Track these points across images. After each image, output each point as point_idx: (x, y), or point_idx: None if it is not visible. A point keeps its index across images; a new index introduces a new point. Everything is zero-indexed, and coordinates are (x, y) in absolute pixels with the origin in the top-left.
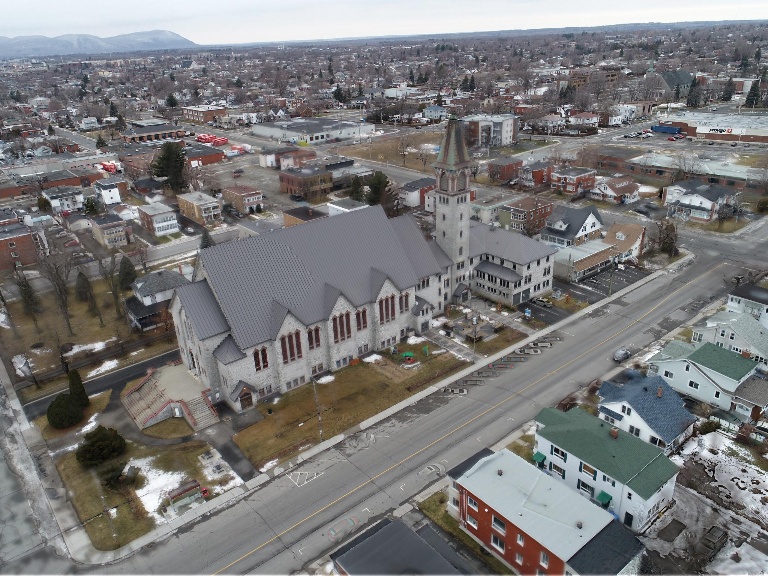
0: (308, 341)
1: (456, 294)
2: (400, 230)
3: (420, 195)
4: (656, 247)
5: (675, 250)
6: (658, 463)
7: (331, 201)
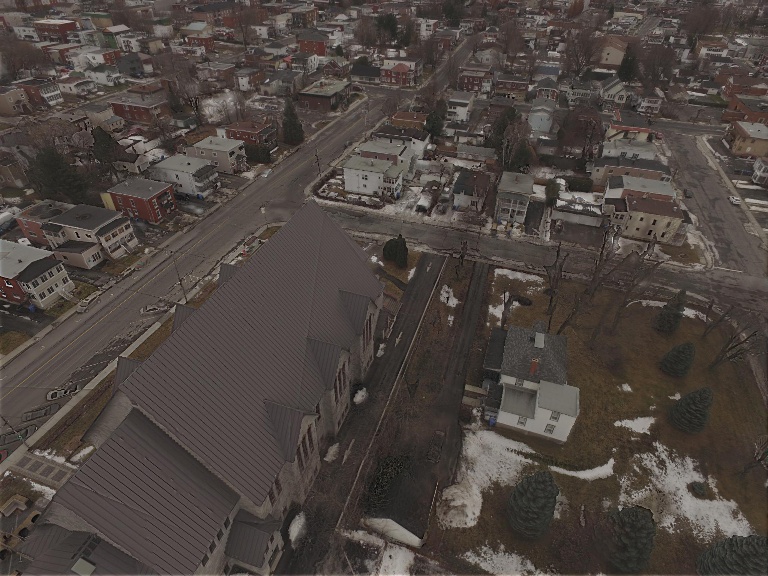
0: None
1: None
2: None
3: None
4: None
5: None
6: None
7: None
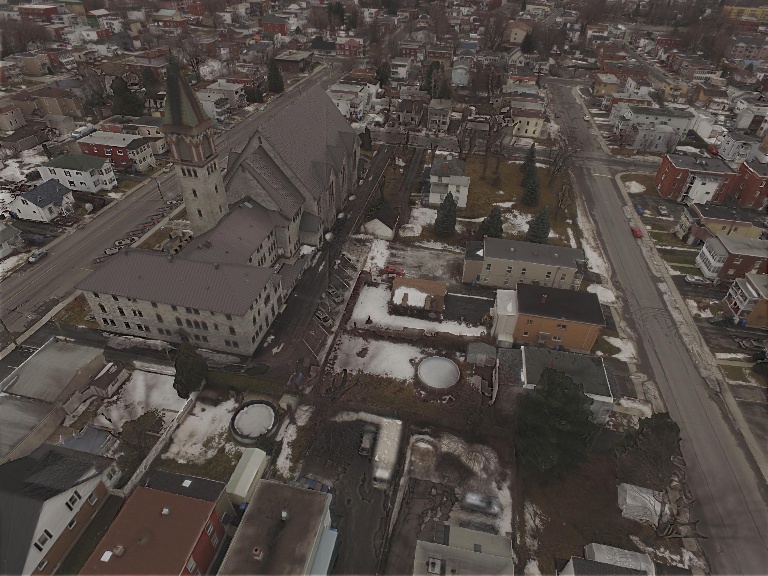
0: None
1: None
2: None
3: None
4: None
5: None
6: None
7: None
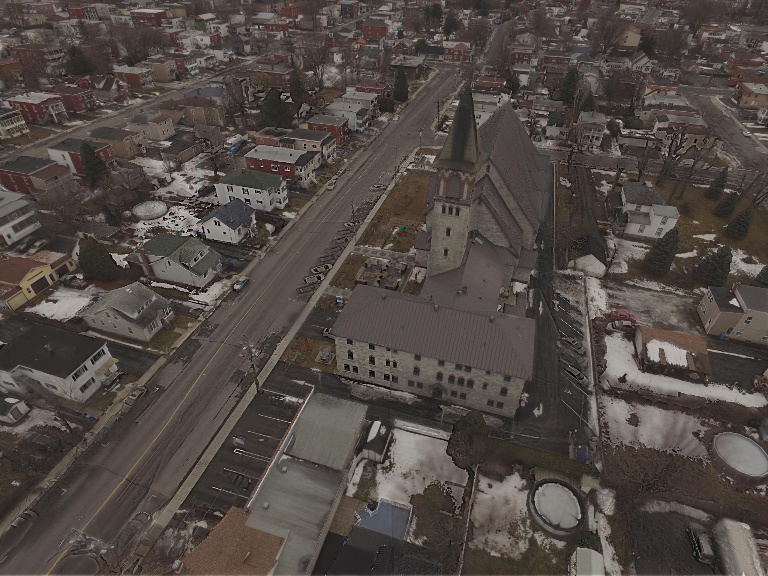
0: None
1: None
2: None
3: None
4: None
5: None
6: None
7: None
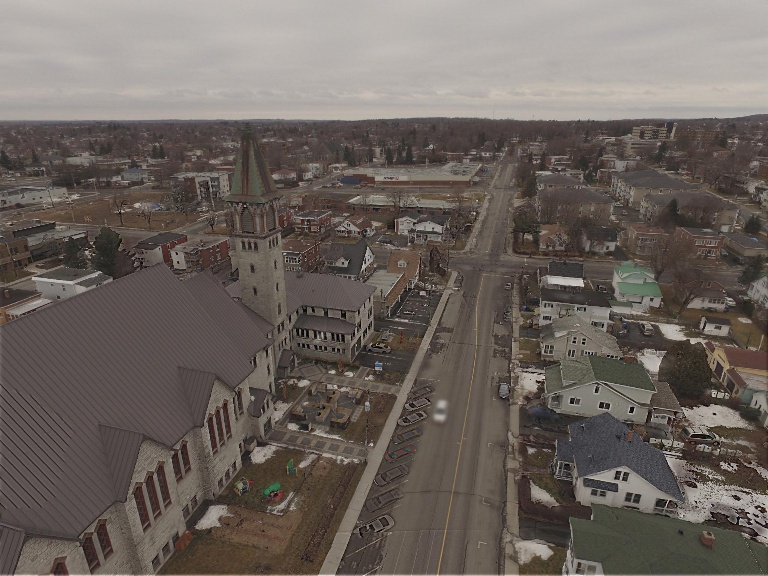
0: (85, 559)
1: (282, 365)
2: (199, 296)
3: (162, 252)
4: (426, 270)
5: (444, 270)
6: (760, 558)
7: (33, 275)
